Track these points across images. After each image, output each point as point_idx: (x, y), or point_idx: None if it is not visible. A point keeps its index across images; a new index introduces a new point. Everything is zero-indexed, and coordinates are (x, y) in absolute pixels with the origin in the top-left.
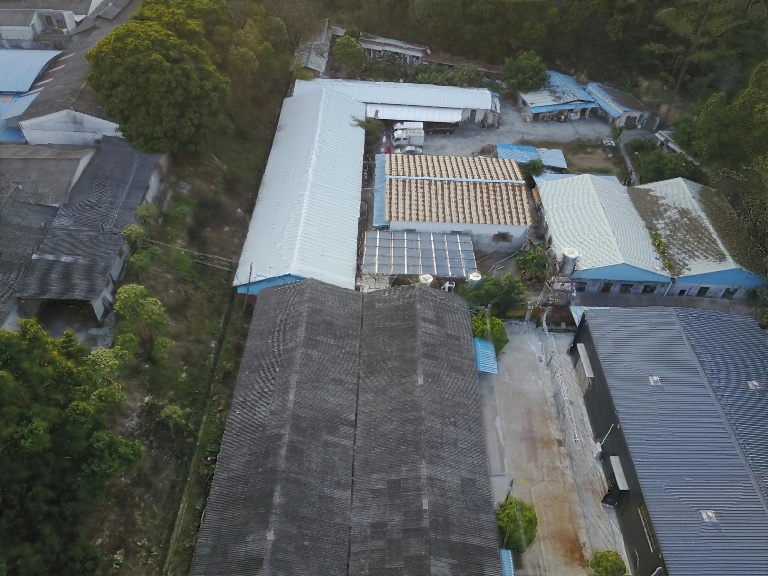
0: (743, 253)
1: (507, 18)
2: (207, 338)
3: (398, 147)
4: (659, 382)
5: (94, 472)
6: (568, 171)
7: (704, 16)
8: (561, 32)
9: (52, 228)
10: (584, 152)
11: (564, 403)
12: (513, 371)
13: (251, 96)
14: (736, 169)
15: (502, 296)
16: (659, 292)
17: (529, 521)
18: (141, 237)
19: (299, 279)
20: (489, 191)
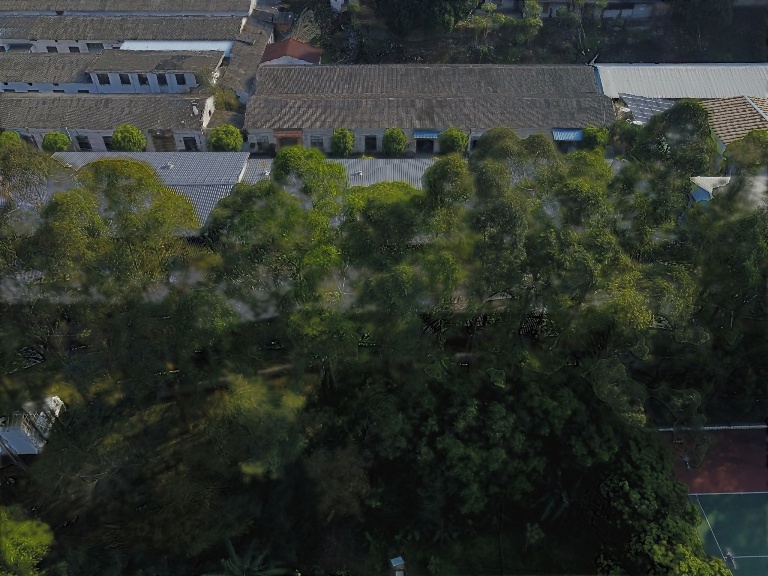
0: None
1: None
2: None
3: None
4: None
5: (435, 11)
6: None
7: None
8: None
9: None
10: None
11: None
12: None
13: None
14: None
15: None
16: None
17: (451, 135)
18: (577, 4)
19: None
20: None
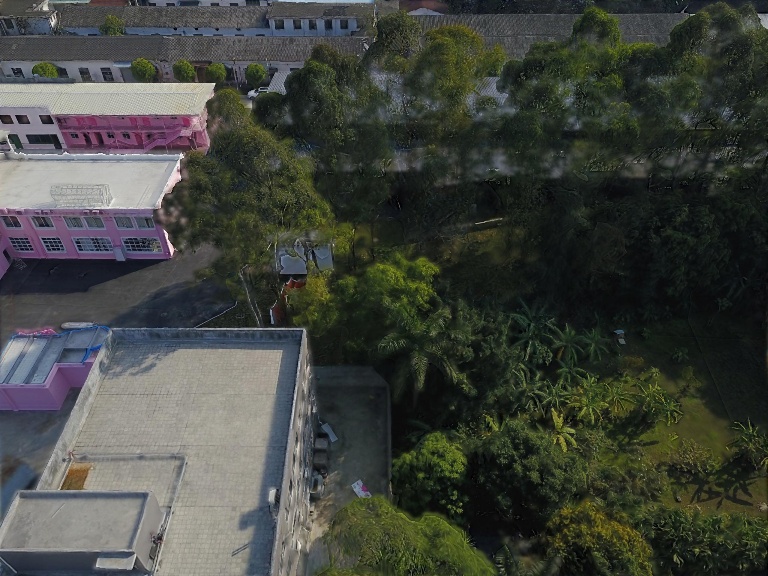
0: None
1: None
2: None
3: None
4: None
5: None
6: None
7: None
8: None
9: None
10: None
11: None
12: None
13: None
14: None
15: None
16: None
17: None
18: None
19: None
20: None
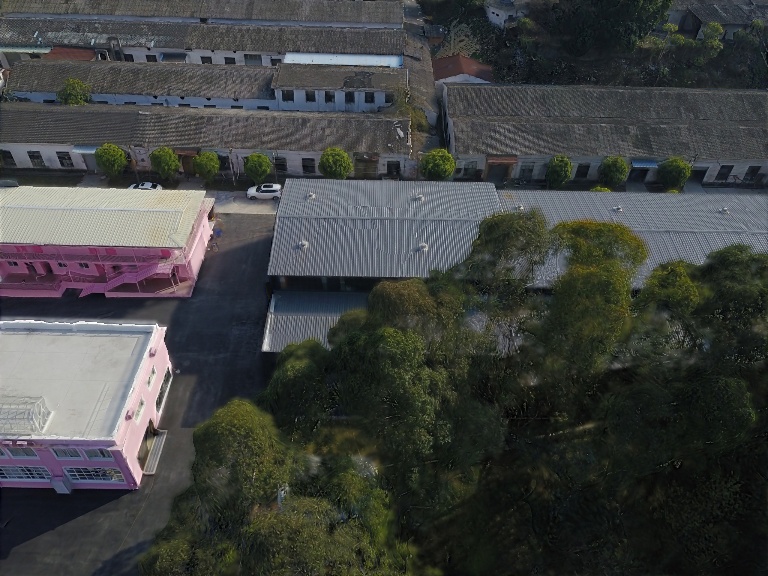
0: None
1: None
2: None
3: None
4: None
5: (620, 31)
6: None
7: None
8: None
9: (737, 5)
10: None
11: None
12: None
13: None
14: None
15: None
16: None
17: (678, 166)
18: (757, 27)
19: None
20: None
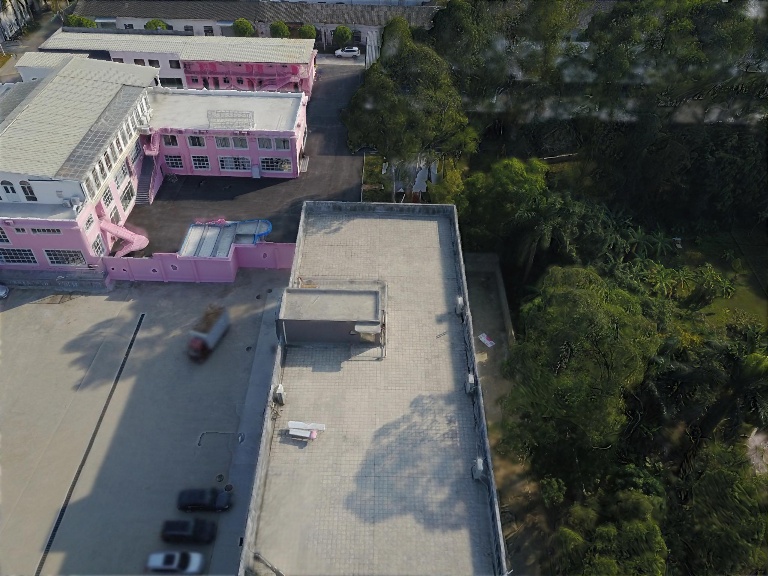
0: None
1: None
2: None
3: None
4: None
5: None
6: None
7: None
8: None
9: None
10: None
11: None
12: None
13: None
14: None
15: None
16: None
17: None
18: None
19: None
20: None
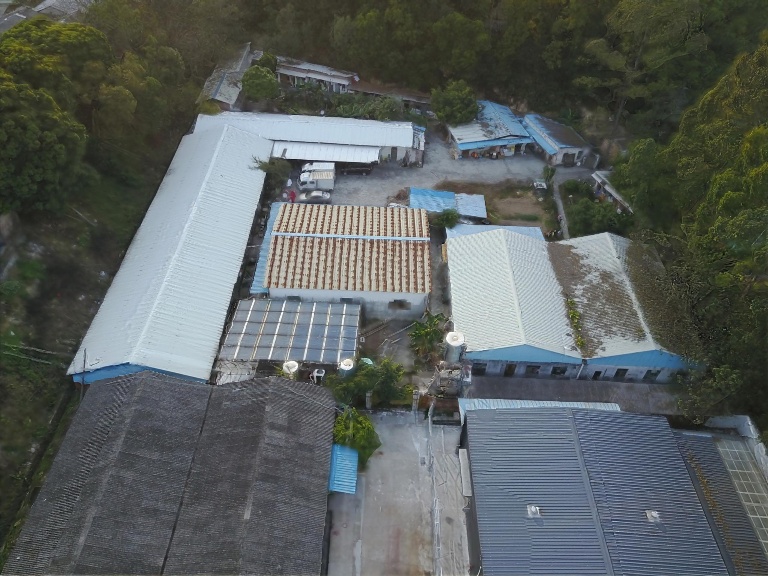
0: (667, 328)
1: (436, 44)
2: (24, 442)
3: (304, 191)
4: (538, 513)
5: None
6: (491, 219)
7: (640, 47)
8: (496, 59)
9: None
10: (513, 195)
11: (435, 527)
12: (388, 478)
13: (146, 133)
14: (669, 223)
15: (381, 385)
16: (571, 374)
17: None
18: None
19: (141, 368)
20: (387, 251)
